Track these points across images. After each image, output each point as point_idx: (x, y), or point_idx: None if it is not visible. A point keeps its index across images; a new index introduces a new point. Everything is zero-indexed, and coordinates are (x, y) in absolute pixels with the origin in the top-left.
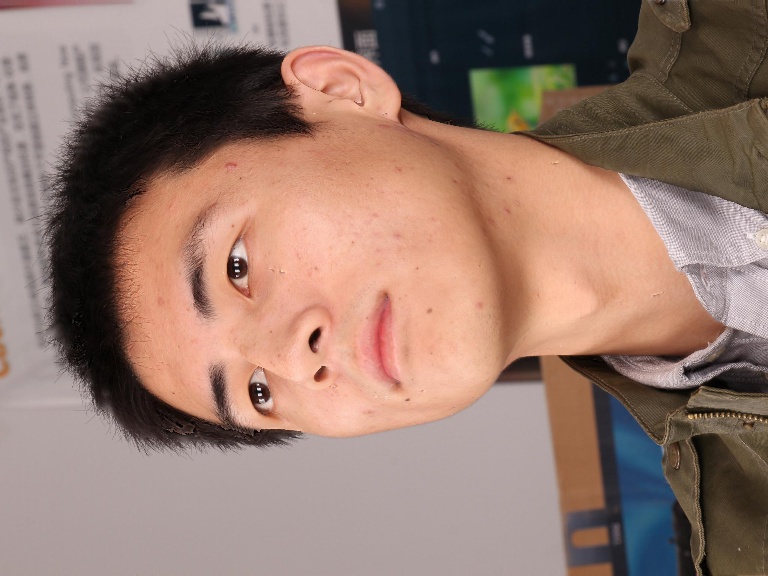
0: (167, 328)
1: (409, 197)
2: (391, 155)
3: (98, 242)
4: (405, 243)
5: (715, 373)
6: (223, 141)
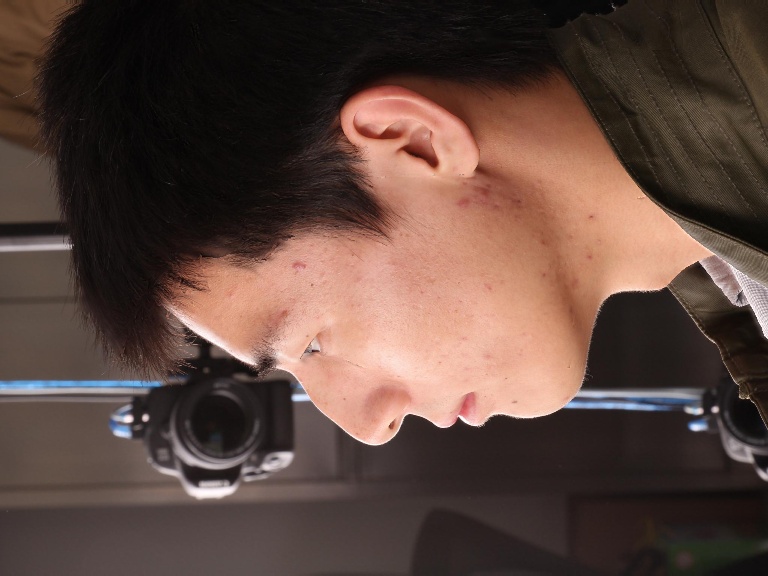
0: None
1: (500, 319)
2: (479, 265)
3: (145, 299)
4: (495, 363)
5: None
6: None
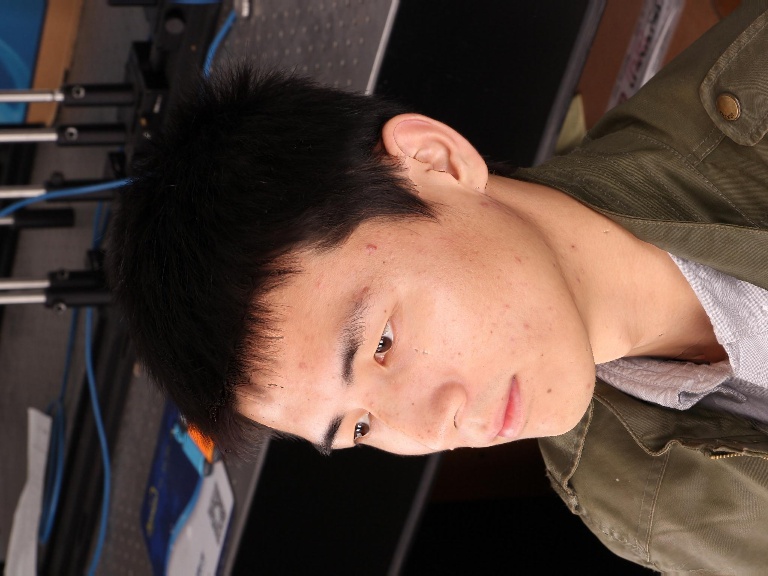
0: (301, 385)
1: (532, 288)
2: (507, 243)
3: (246, 309)
4: (533, 333)
5: (699, 398)
6: (359, 221)
